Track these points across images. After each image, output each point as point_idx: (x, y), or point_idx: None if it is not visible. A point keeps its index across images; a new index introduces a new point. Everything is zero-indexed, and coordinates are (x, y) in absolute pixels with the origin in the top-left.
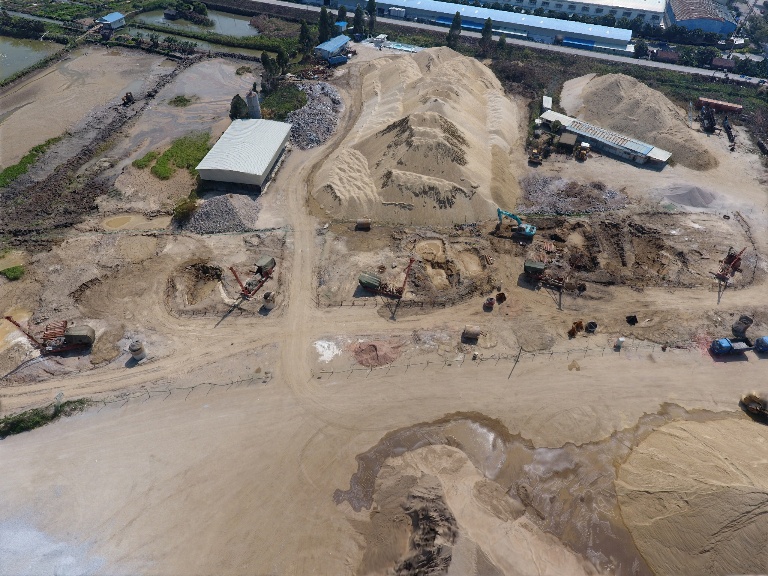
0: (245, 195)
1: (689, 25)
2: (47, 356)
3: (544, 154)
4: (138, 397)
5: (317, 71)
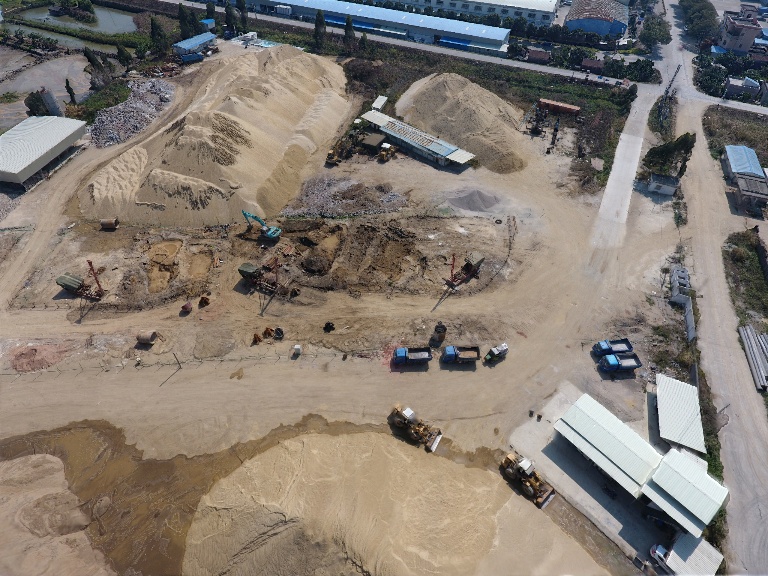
0: None
1: (579, 25)
2: None
3: (346, 155)
4: None
5: (166, 68)
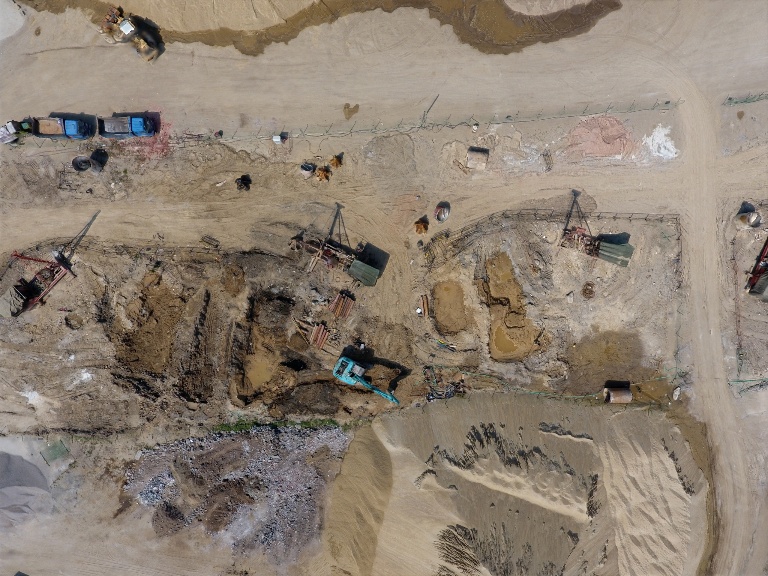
0: None
1: None
2: None
3: None
4: None
5: None
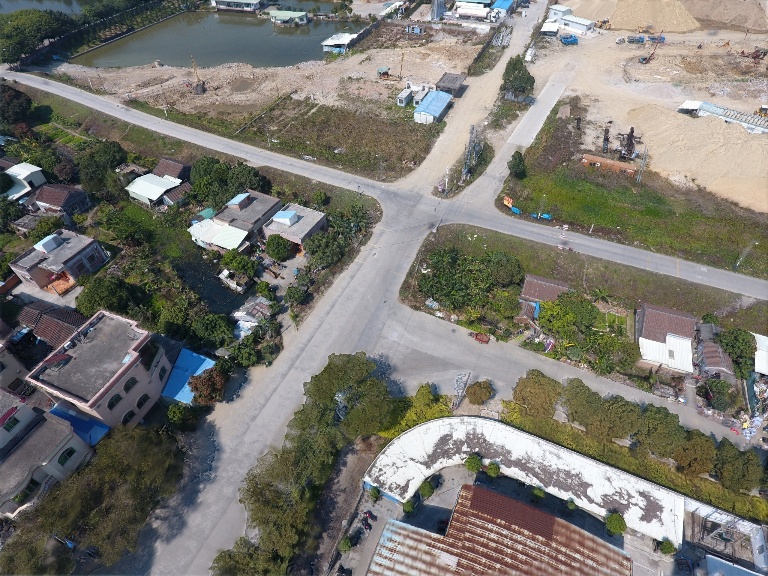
0: None
1: None
2: None
3: None
4: None
5: None
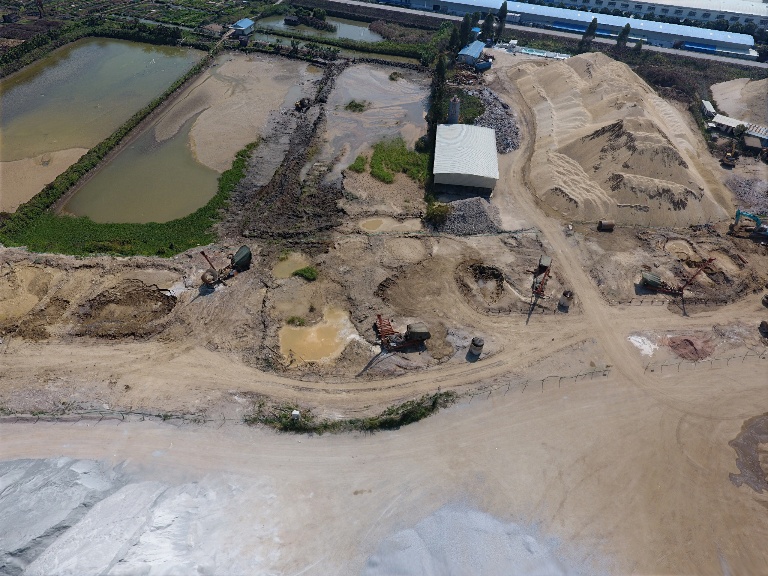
0: (482, 198)
1: None
2: (391, 352)
3: (733, 157)
4: (498, 389)
5: (468, 76)
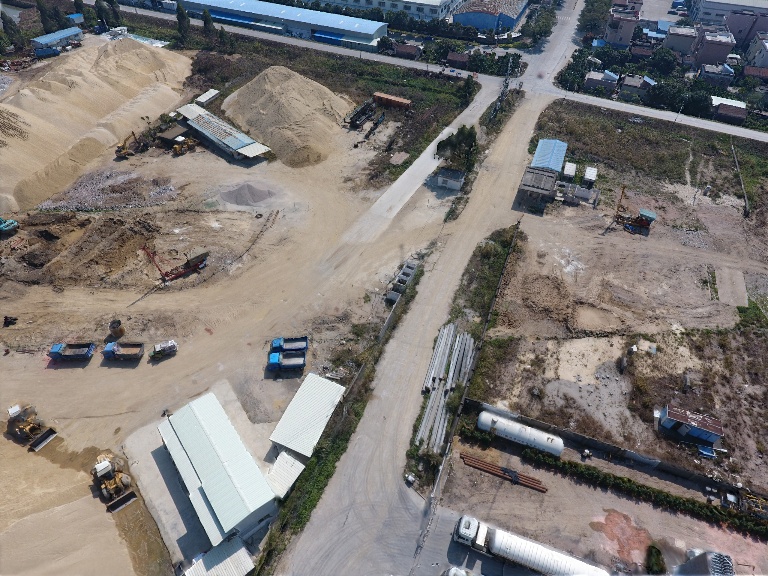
0: None
1: (465, 19)
2: None
3: (141, 148)
4: None
5: (16, 63)
